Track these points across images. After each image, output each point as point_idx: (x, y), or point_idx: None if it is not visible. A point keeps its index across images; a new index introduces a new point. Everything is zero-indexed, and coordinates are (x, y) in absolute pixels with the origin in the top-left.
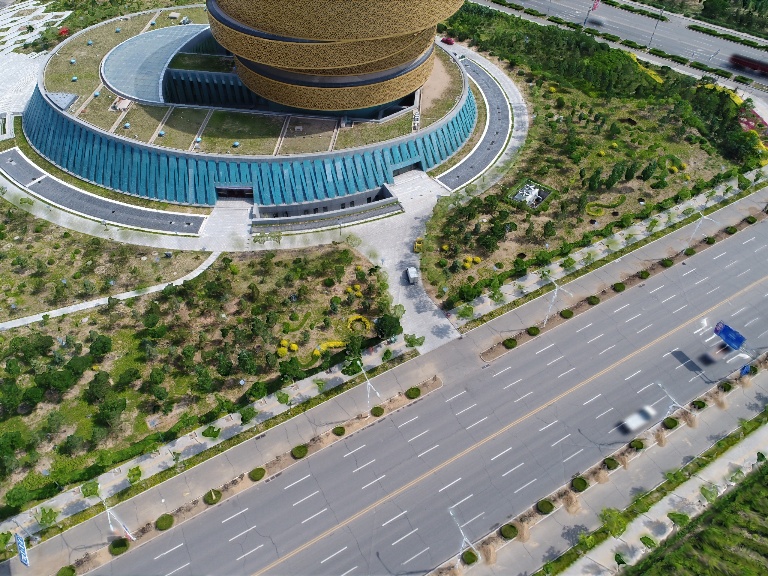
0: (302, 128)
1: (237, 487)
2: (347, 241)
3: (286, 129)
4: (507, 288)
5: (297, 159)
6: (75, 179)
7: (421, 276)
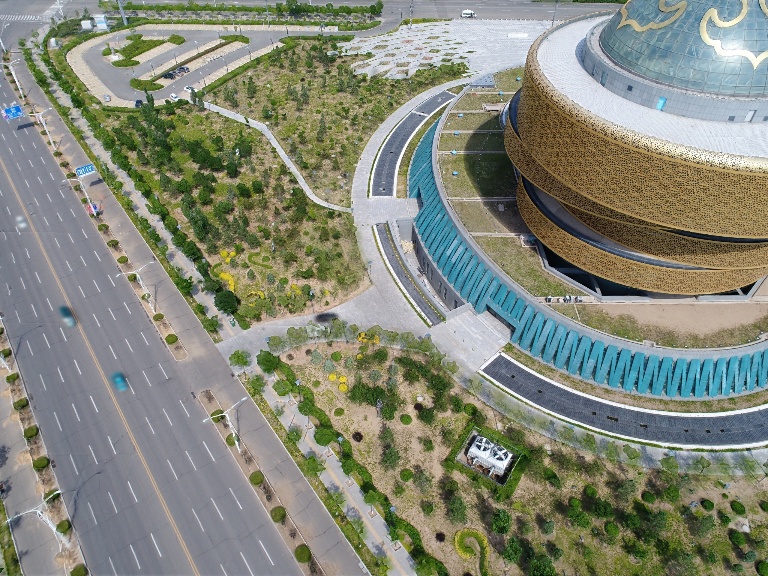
0: (504, 210)
1: (117, 253)
2: None
3: (497, 200)
4: (302, 419)
5: None
6: None
7: (321, 342)
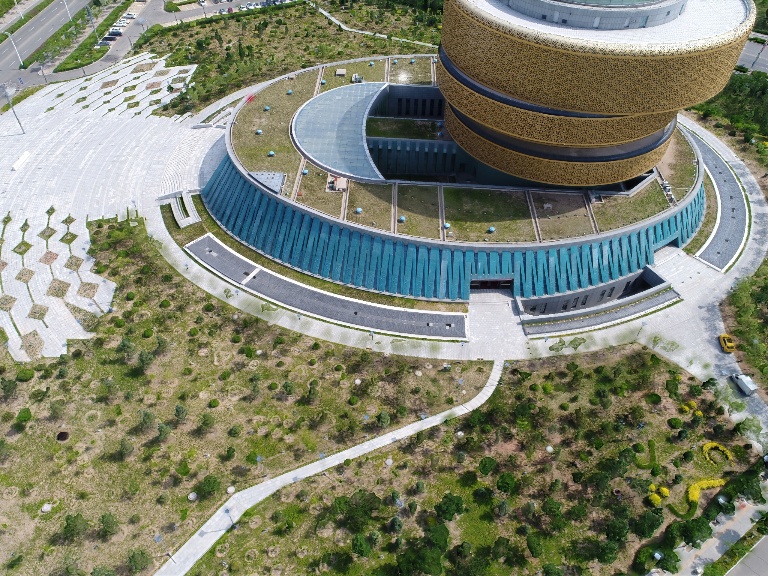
0: (550, 206)
1: None
2: (656, 345)
3: (534, 208)
4: None
5: (565, 245)
6: (294, 272)
7: None
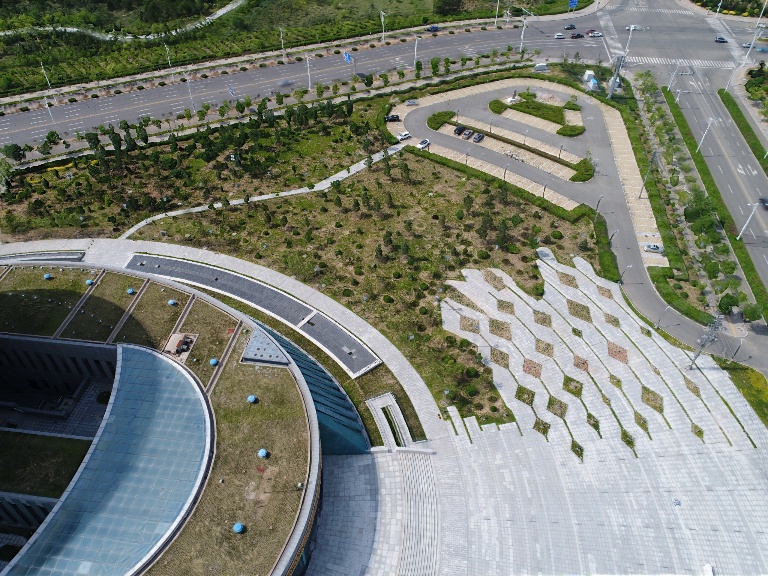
0: None
1: None
2: (0, 220)
3: None
4: None
5: None
6: (263, 322)
7: None
